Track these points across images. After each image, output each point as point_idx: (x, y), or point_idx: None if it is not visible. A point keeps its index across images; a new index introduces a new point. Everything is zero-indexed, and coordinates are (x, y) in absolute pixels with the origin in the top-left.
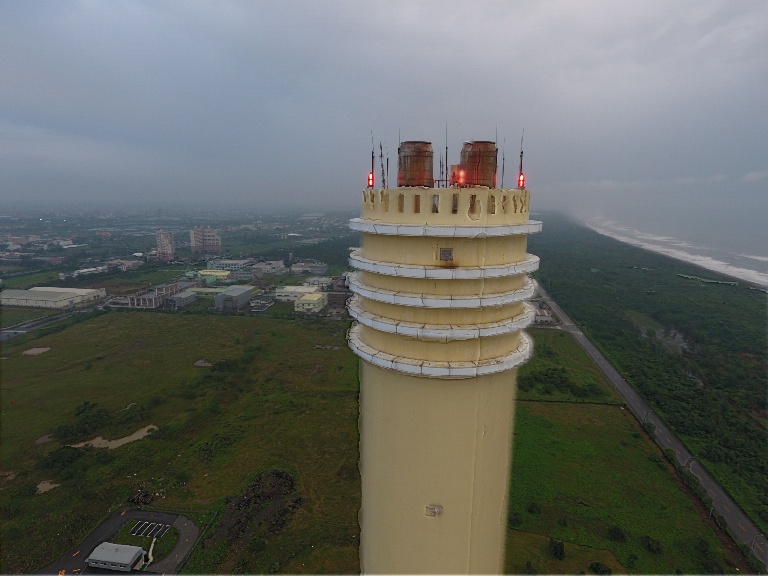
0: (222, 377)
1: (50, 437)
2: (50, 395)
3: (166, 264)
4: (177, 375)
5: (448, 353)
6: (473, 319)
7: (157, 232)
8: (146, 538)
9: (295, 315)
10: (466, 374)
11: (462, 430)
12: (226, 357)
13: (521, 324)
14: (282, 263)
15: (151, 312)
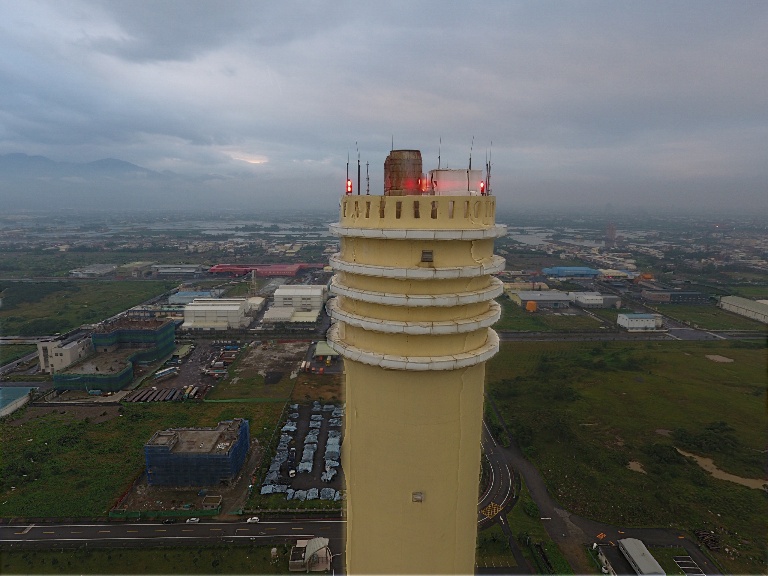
0: None
1: (670, 433)
2: (698, 400)
3: None
4: None
5: None
6: (341, 304)
7: None
8: (683, 574)
9: None
10: None
11: None
12: None
13: (363, 324)
14: None
15: None
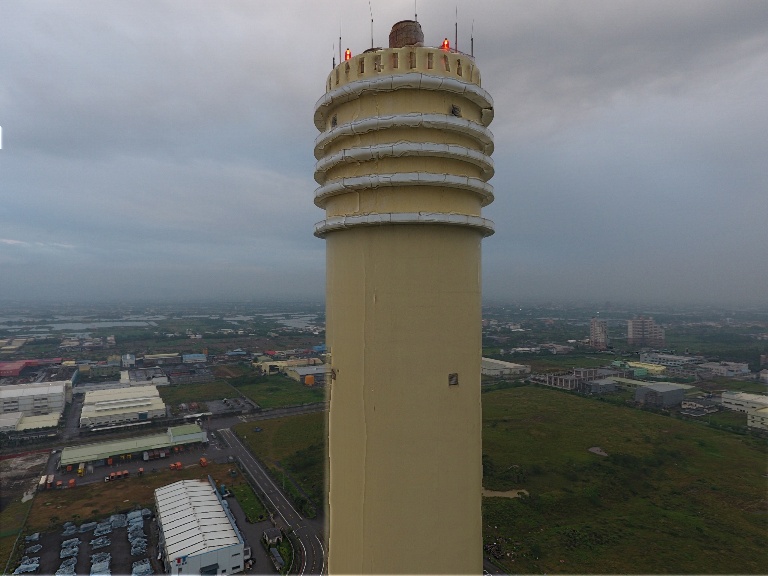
0: (613, 470)
1: None
2: None
3: (596, 352)
4: (567, 454)
5: (339, 210)
6: (351, 174)
7: (591, 320)
8: None
9: (746, 430)
10: (335, 222)
11: (354, 291)
12: (627, 452)
13: (399, 176)
14: (746, 366)
15: (564, 392)
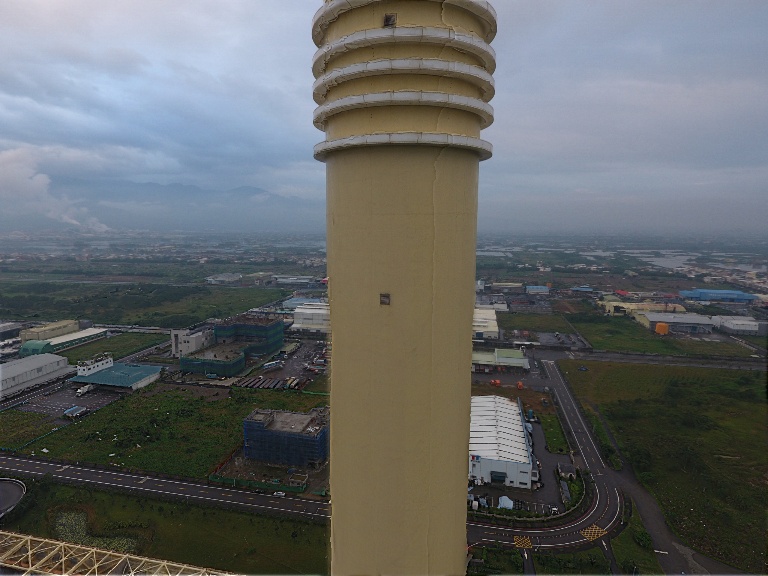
0: None
1: None
2: None
3: None
4: None
5: None
6: None
7: None
8: None
9: None
10: None
11: None
12: None
13: (329, 105)
14: None
15: None
